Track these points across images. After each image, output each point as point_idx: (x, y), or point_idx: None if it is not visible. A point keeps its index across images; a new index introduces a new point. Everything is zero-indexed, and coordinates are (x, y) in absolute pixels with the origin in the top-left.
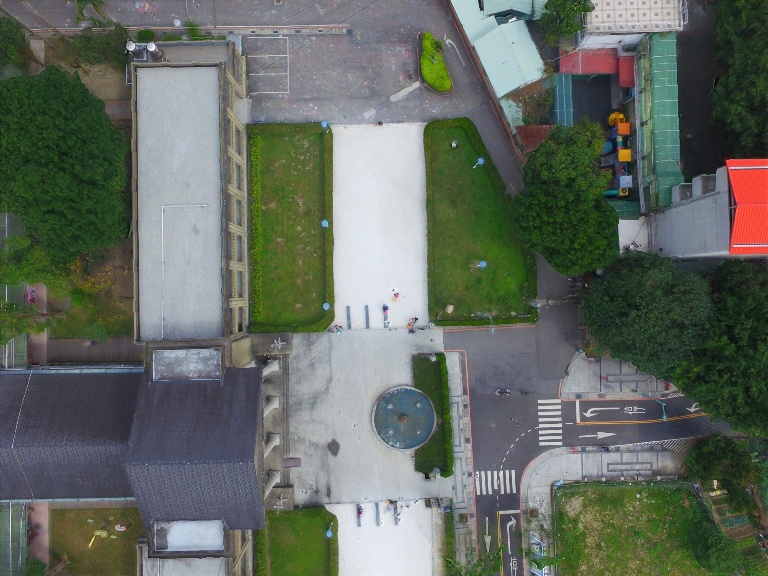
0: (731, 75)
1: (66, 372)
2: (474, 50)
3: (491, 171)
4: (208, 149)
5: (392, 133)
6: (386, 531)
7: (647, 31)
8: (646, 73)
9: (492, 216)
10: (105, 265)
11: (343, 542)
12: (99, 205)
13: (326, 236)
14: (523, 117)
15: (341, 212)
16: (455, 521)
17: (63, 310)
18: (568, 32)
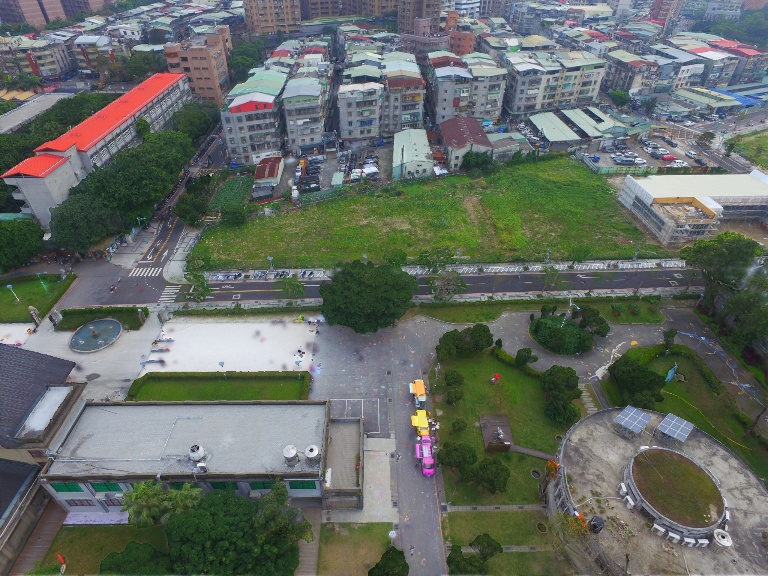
0: None
1: None
2: None
3: None
4: None
5: None
6: (176, 347)
7: None
8: None
9: None
10: None
11: None
12: None
13: None
14: None
15: None
16: None
17: None
18: None
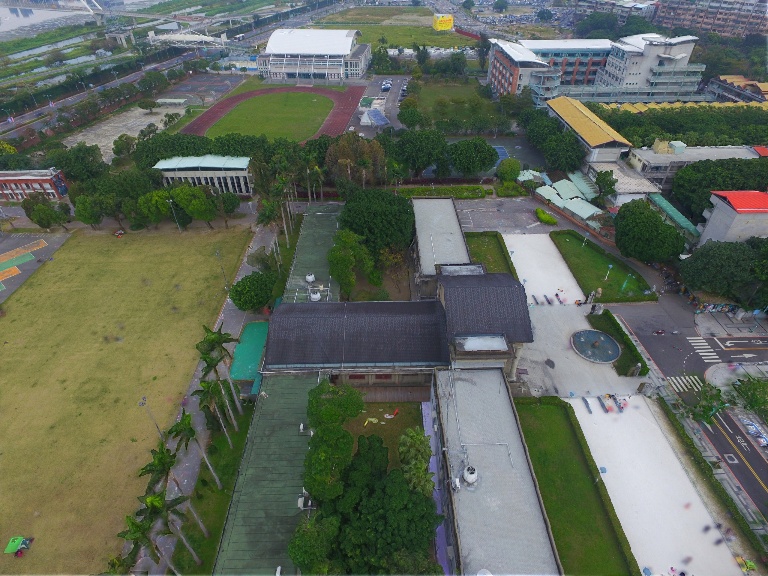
0: (695, 200)
1: (368, 302)
2: (564, 211)
3: (593, 245)
4: (451, 218)
5: (532, 237)
6: (615, 418)
7: (645, 192)
8: (654, 208)
9: (603, 262)
10: (401, 251)
11: (582, 426)
12: (408, 220)
13: (510, 266)
14: (601, 224)
15: (514, 261)
16: (670, 406)
17: (351, 298)
18: (609, 191)
